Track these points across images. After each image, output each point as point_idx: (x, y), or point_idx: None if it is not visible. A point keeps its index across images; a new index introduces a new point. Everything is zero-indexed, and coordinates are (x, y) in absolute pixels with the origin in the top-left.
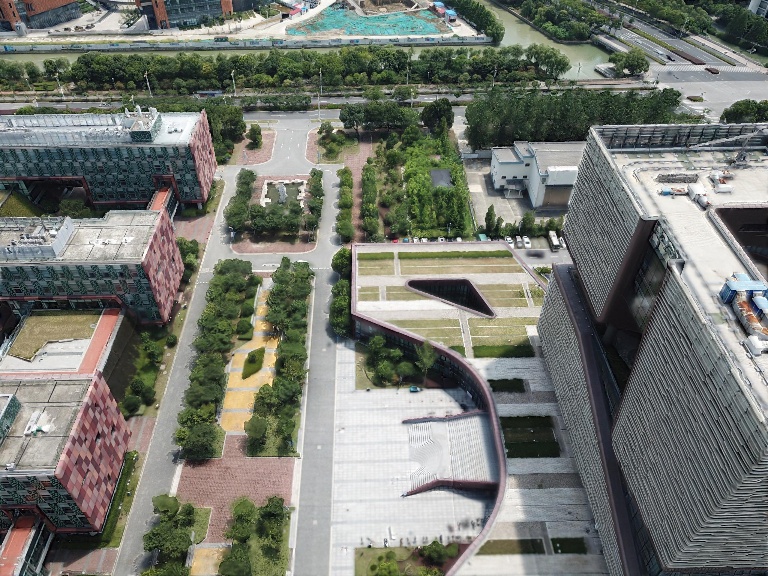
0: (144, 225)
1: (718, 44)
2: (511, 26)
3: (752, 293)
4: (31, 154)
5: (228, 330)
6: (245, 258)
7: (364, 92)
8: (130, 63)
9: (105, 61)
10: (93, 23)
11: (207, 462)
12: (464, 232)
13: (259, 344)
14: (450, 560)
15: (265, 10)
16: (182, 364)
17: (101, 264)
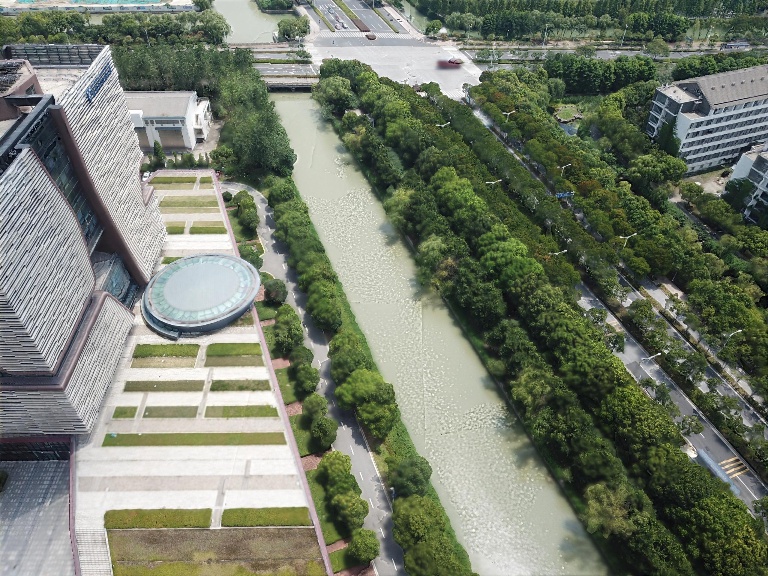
0: None
1: (400, 14)
2: None
3: None
4: None
5: None
6: None
7: None
8: None
9: None
10: None
11: None
12: None
13: None
14: None
15: None
16: None
17: None
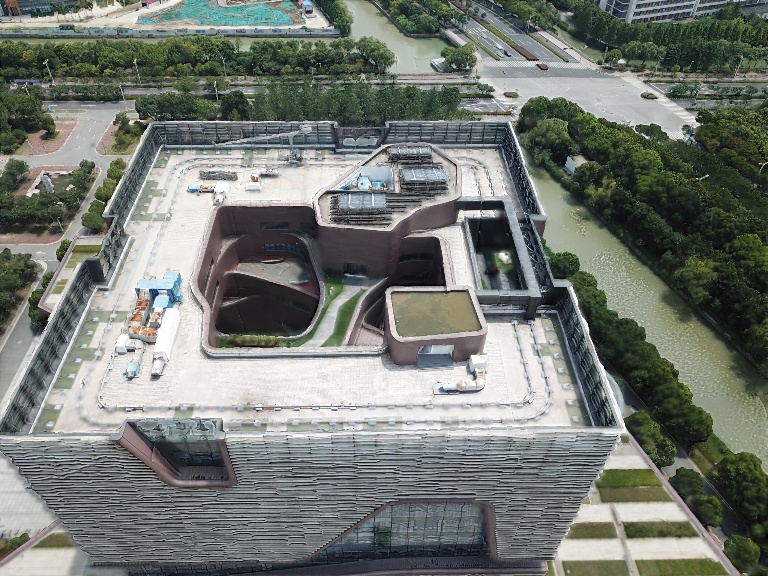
0: None
1: (561, 40)
2: (374, 18)
3: (157, 291)
4: None
5: None
6: None
7: (176, 83)
8: None
9: None
10: None
11: None
12: None
13: None
14: None
15: None
16: None
17: None
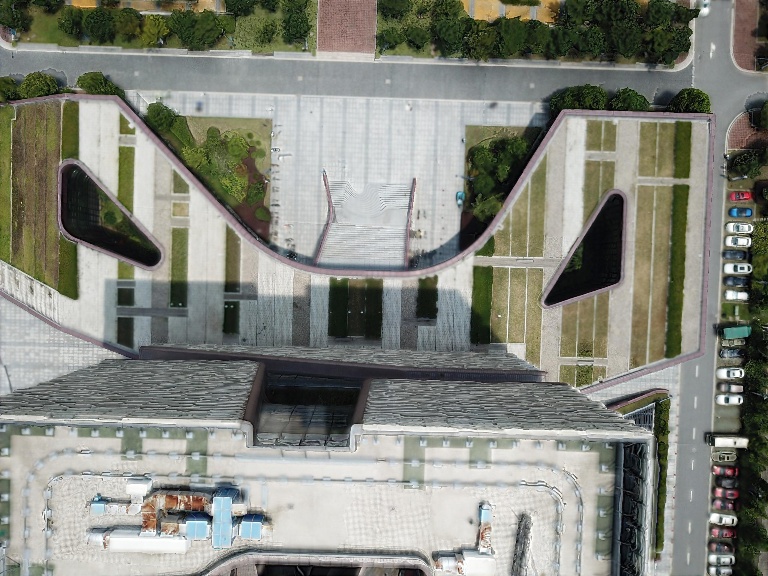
0: None
1: None
2: None
3: None
4: None
5: None
6: None
7: None
8: None
9: None
10: None
11: None
12: None
13: None
14: (253, 210)
15: None
16: None
17: None
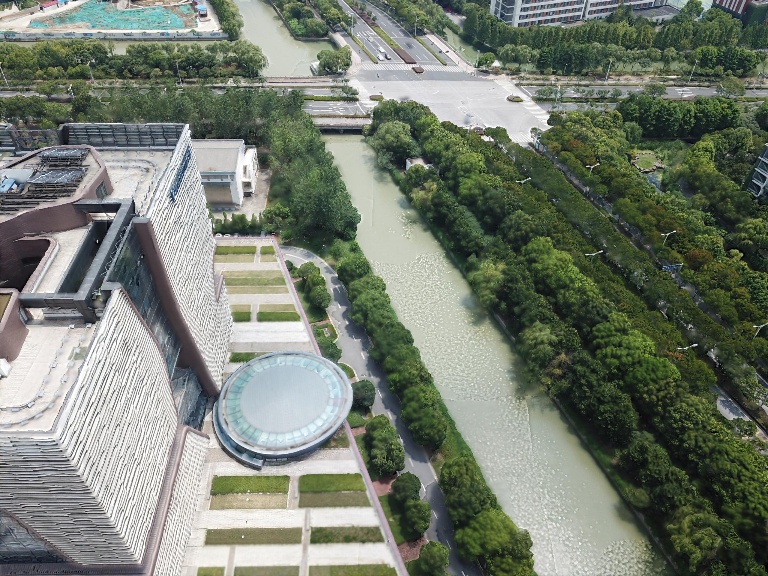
0: None
1: (445, 43)
2: (273, 22)
3: None
4: None
5: None
6: None
7: None
8: None
9: None
10: None
11: None
12: None
13: None
14: None
15: (20, 2)
16: None
17: None
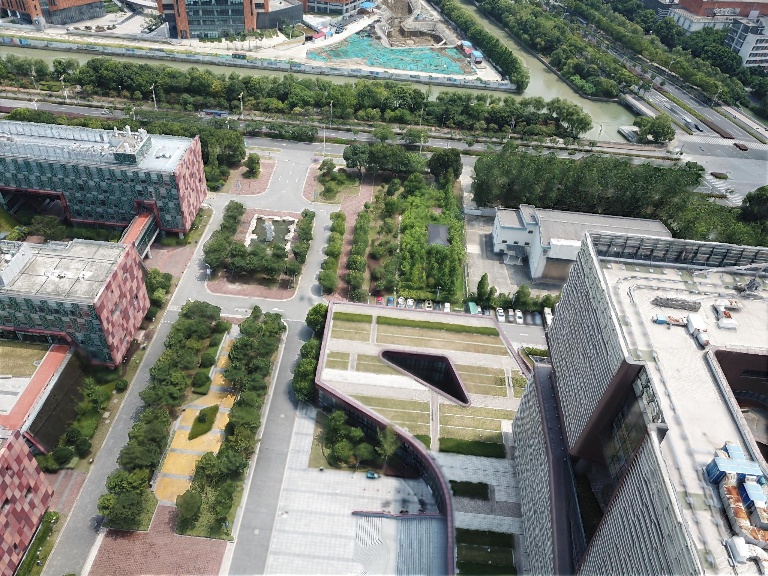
0: (107, 260)
1: (750, 118)
2: (538, 74)
3: (744, 477)
4: (10, 164)
5: (181, 383)
6: (218, 299)
7: (374, 130)
8: (139, 73)
9: (114, 68)
10: (115, 24)
11: (131, 535)
12: (454, 297)
13: (214, 401)
14: None
15: (289, 30)
16: (128, 414)
17: (51, 300)
